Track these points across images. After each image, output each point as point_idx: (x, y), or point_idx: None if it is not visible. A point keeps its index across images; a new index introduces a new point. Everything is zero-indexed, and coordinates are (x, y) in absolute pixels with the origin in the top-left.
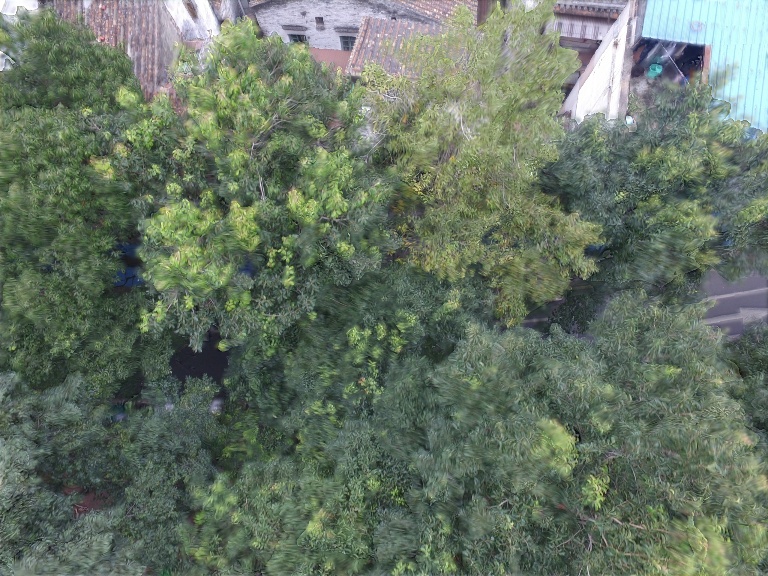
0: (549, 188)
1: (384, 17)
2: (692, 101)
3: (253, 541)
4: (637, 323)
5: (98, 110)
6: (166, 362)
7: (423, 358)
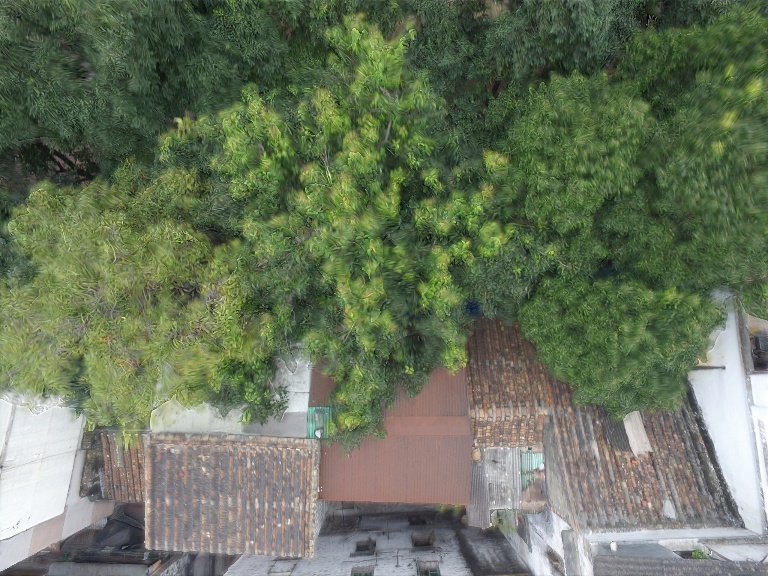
0: None
1: None
2: None
3: None
4: None
5: (553, 280)
6: (463, 130)
7: (203, 118)
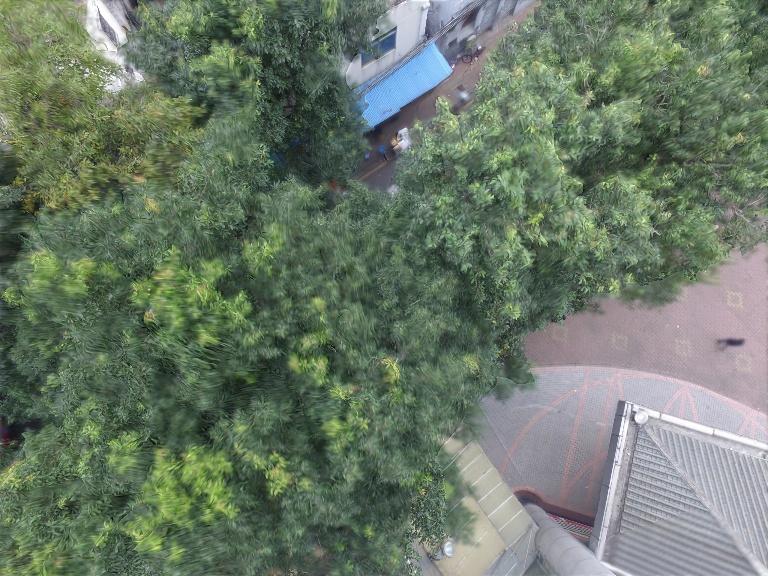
0: (157, 87)
1: None
2: None
3: (6, 519)
4: None
5: None
6: None
7: None
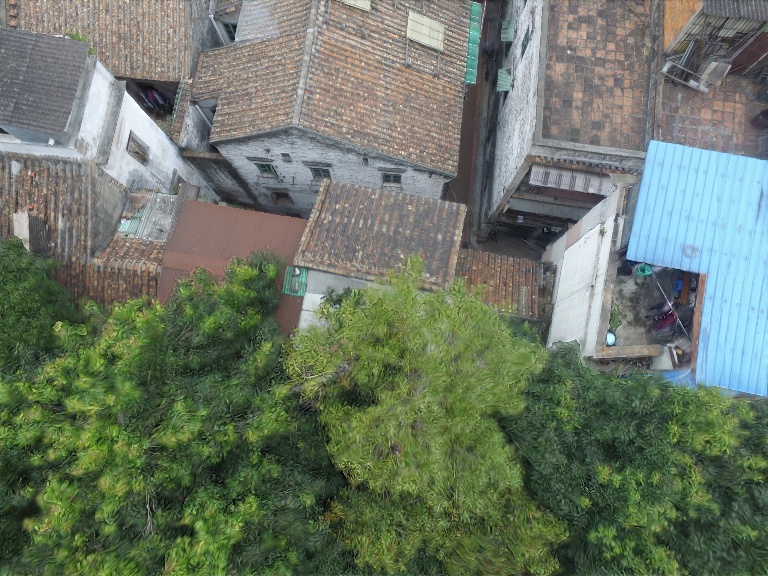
0: (510, 437)
1: (355, 157)
2: (672, 412)
3: None
4: None
5: None
6: None
7: None
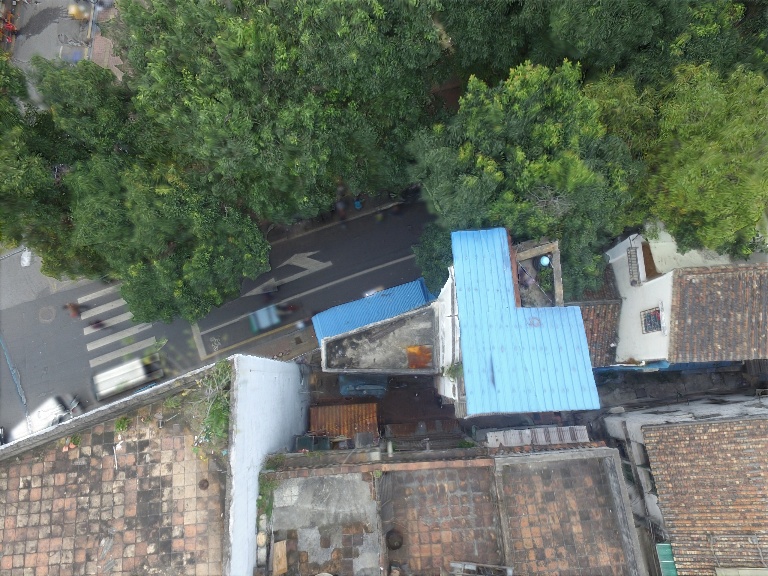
0: None
1: None
2: None
3: None
4: (596, 6)
5: None
6: None
7: None
